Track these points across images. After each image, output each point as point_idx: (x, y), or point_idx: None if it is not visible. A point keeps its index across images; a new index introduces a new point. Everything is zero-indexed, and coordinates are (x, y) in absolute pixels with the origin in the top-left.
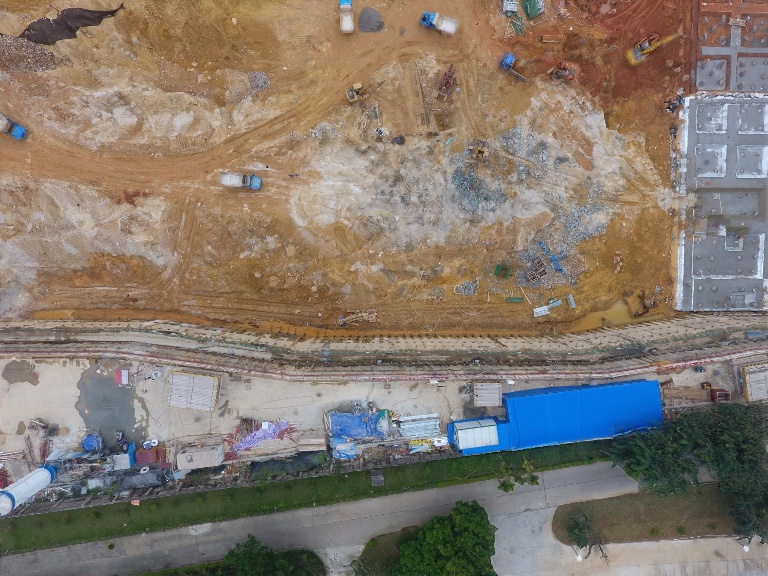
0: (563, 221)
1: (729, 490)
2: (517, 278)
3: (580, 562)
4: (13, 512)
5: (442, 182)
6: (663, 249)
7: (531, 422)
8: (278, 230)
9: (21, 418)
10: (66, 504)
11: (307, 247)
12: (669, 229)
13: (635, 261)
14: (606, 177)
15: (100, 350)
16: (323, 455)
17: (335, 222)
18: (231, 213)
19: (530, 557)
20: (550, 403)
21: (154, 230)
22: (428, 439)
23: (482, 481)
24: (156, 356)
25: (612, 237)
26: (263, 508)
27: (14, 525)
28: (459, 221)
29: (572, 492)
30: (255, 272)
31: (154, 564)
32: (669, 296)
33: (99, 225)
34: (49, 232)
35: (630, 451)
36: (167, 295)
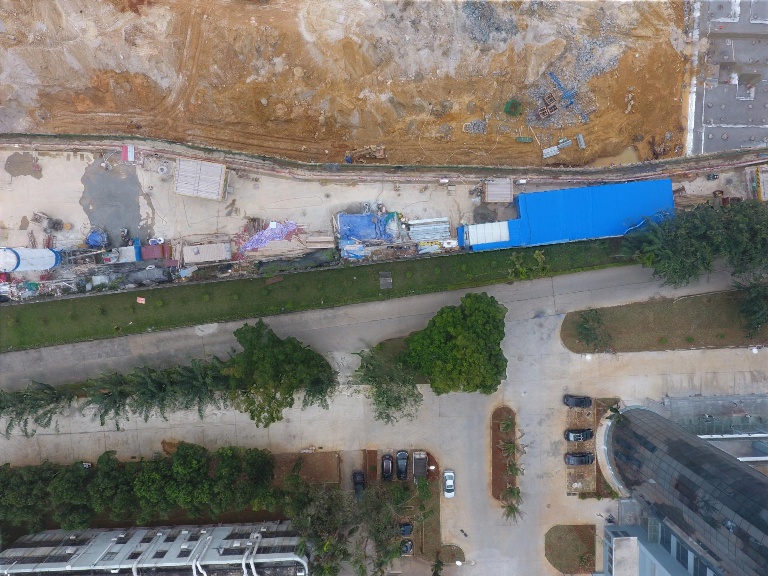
0: (575, 53)
1: (740, 285)
2: (527, 116)
3: (588, 371)
4: (17, 302)
5: (453, 10)
6: (674, 92)
7: (542, 218)
8: (286, 48)
9: (24, 213)
10: (71, 295)
11: (315, 69)
12: (681, 73)
13: (646, 99)
14: (619, 9)
15: (105, 144)
16: (332, 251)
17: (344, 37)
18: (238, 26)
19: (538, 365)
20: (562, 199)
21: (159, 43)
22: (438, 241)
23: (491, 286)
24: (162, 152)
25: (624, 71)
26: (270, 309)
27: (18, 320)
28: (470, 49)
29: (581, 299)
30: (261, 98)
31: (160, 364)
32: (679, 144)
33: (102, 34)
34: (51, 44)
35: (642, 241)
36: (171, 123)
